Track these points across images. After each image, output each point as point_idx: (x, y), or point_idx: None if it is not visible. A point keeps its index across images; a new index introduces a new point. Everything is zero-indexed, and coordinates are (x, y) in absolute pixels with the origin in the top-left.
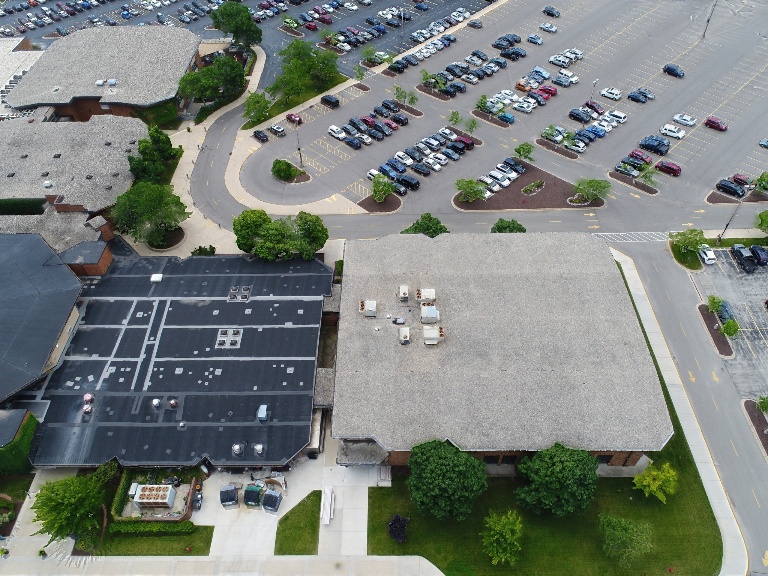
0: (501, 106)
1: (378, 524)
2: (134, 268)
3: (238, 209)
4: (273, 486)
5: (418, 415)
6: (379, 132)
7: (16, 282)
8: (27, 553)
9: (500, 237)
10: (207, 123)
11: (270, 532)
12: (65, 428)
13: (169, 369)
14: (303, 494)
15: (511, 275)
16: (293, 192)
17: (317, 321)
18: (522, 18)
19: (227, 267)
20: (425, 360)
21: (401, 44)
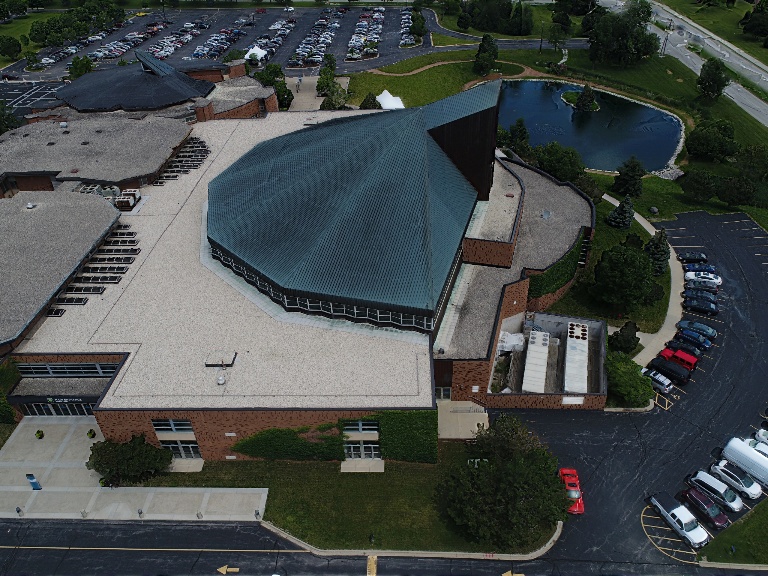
0: None
1: None
2: None
3: None
4: None
5: None
6: None
7: None
8: None
9: None
10: None
11: None
12: None
13: (21, 90)
14: None
15: None
16: None
17: None
18: None
19: None
20: None
21: None
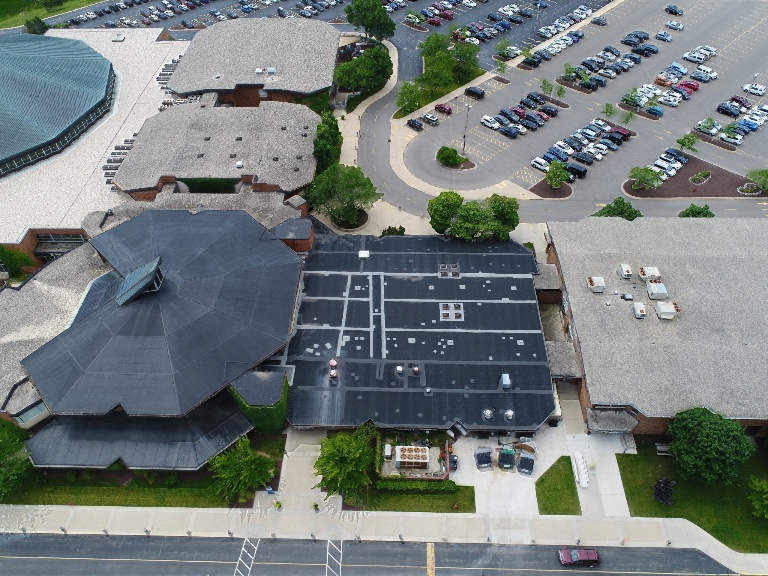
0: (646, 100)
1: (634, 488)
2: (336, 245)
3: (412, 193)
4: (521, 451)
5: (671, 384)
6: (533, 122)
7: (240, 254)
8: (299, 507)
9: (698, 221)
10: (358, 112)
11: (530, 493)
12: (315, 391)
13: (402, 339)
14: (552, 459)
15: (724, 256)
16: (462, 178)
17: (533, 297)
18: (645, 16)
19: (426, 246)
20: (664, 333)
21: (529, 39)
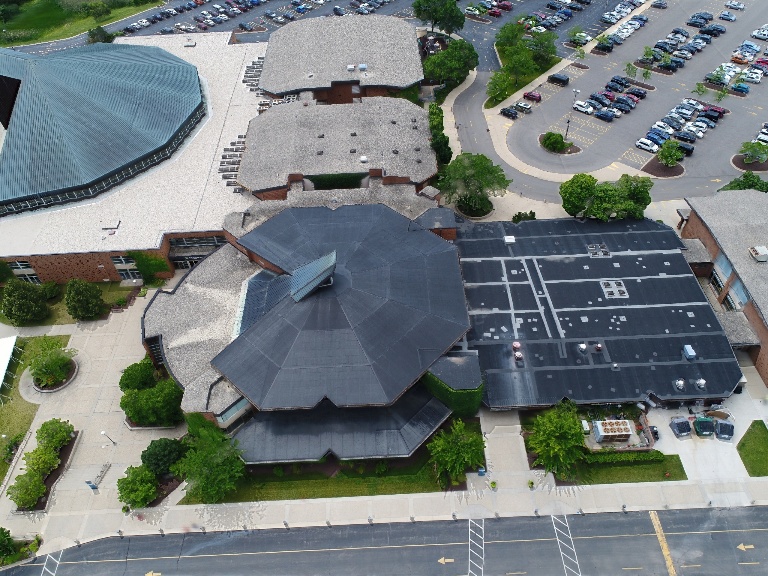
0: (729, 78)
1: None
2: (476, 233)
3: (527, 179)
4: (714, 418)
5: None
6: (626, 105)
7: (396, 246)
8: (513, 486)
9: None
10: (448, 104)
11: (734, 457)
12: (504, 373)
13: (574, 318)
14: (746, 424)
15: None
16: (571, 162)
17: (689, 271)
18: None
19: (566, 228)
20: None
21: (595, 26)
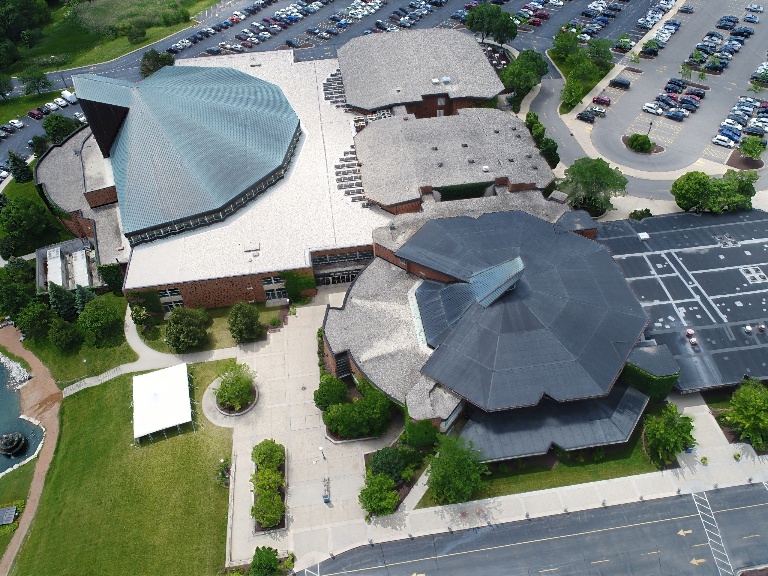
0: None
1: None
2: (608, 232)
3: None
4: None
5: None
6: (692, 105)
7: (553, 248)
8: (720, 459)
9: None
10: (525, 111)
11: None
12: (685, 359)
13: (730, 303)
14: None
15: None
16: (660, 161)
17: None
18: (723, 2)
19: (687, 222)
20: None
21: (634, 31)
